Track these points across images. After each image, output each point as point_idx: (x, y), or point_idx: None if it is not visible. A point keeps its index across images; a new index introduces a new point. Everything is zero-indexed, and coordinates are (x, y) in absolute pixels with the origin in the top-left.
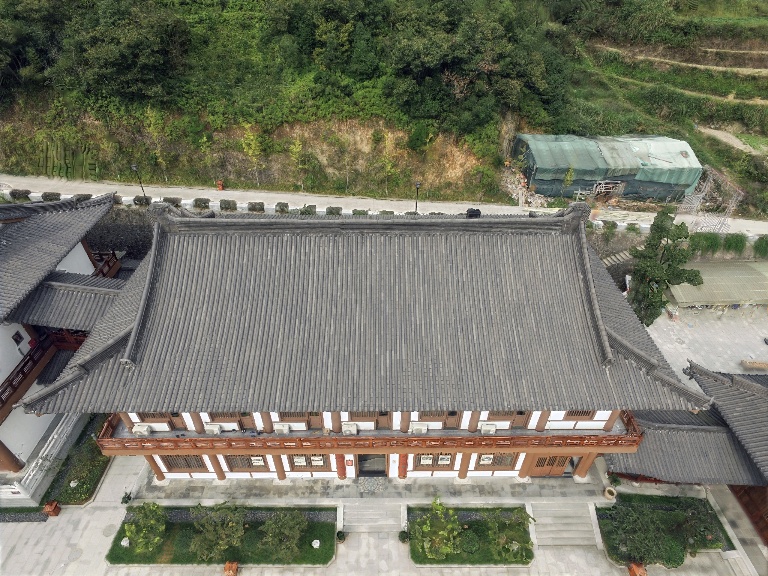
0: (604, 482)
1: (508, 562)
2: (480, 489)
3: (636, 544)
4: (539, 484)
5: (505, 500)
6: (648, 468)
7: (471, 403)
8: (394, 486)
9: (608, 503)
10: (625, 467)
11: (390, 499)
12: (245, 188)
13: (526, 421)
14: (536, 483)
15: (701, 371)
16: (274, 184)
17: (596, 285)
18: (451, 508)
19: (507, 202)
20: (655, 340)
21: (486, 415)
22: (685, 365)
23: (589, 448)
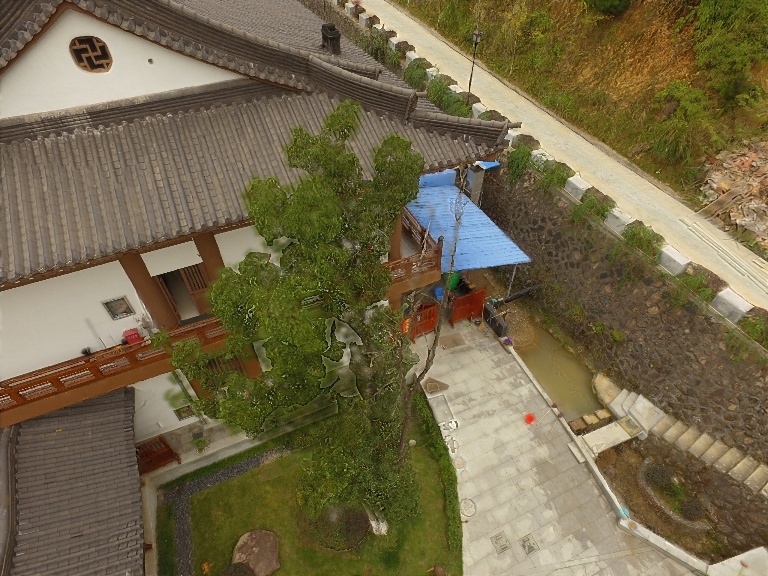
0: None
1: None
2: None
3: None
4: None
5: None
6: None
7: None
8: None
9: None
10: None
11: None
12: (396, 2)
13: None
14: None
15: None
16: (422, 8)
17: (115, 185)
18: None
19: (682, 191)
20: None
21: None
22: None
23: None
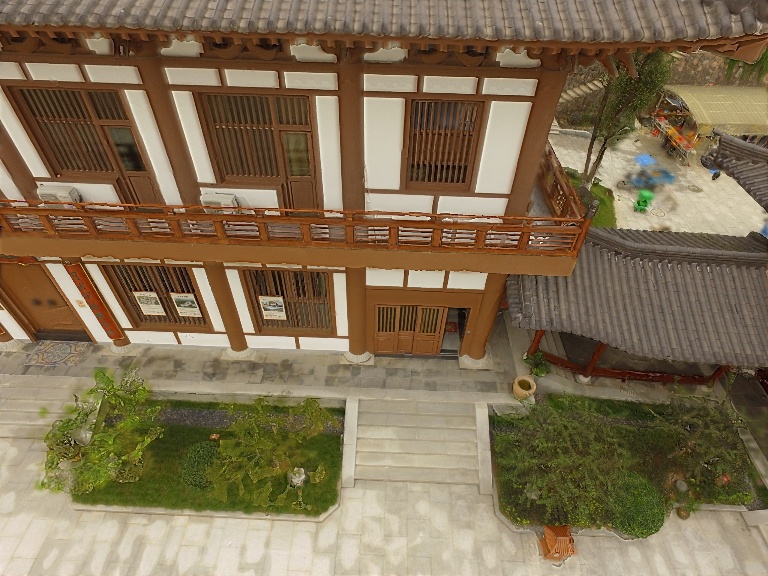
0: (518, 369)
1: (275, 509)
2: (266, 370)
3: (552, 483)
4: (387, 367)
5: (308, 391)
6: (603, 325)
7: (7, 5)
8: (99, 358)
9: (519, 406)
10: (549, 318)
11: (78, 379)
12: None
13: (317, 194)
14: (382, 365)
15: (741, 149)
16: None
17: None
18: (203, 403)
19: None
20: (654, 185)
21: (208, 165)
22: (700, 217)
23: (457, 256)
